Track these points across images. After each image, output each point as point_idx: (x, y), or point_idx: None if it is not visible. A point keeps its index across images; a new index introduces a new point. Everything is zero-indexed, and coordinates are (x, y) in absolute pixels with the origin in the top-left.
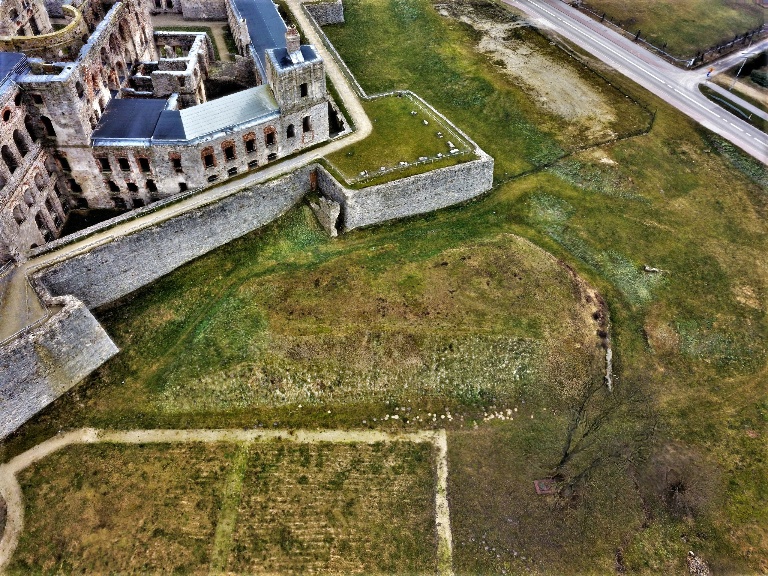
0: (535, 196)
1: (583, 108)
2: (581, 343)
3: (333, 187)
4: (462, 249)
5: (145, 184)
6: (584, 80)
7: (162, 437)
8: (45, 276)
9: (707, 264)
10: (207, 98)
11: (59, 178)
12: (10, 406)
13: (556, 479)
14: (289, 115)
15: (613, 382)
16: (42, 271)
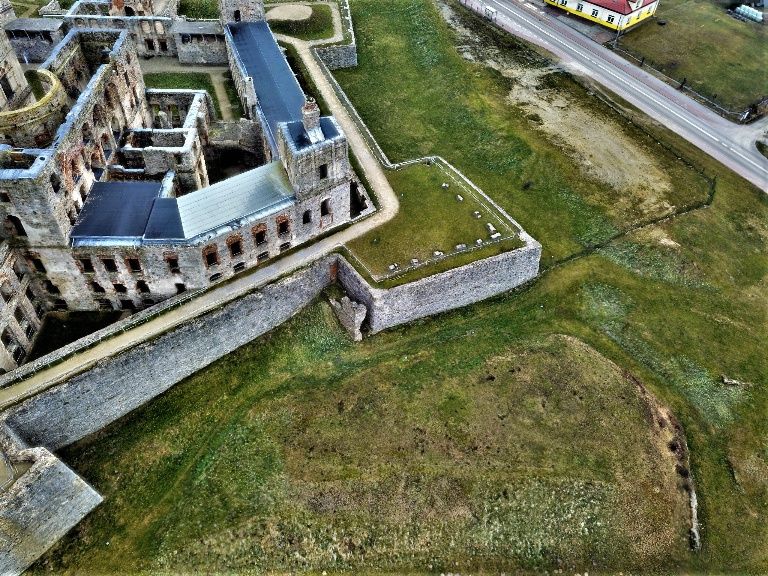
0: (587, 285)
1: (633, 174)
2: (660, 486)
3: (357, 284)
4: (509, 357)
5: (135, 285)
6: (630, 138)
7: None
8: (11, 418)
9: None
10: (207, 164)
11: (32, 280)
12: None
13: None
14: (306, 200)
15: (699, 534)
16: (7, 411)
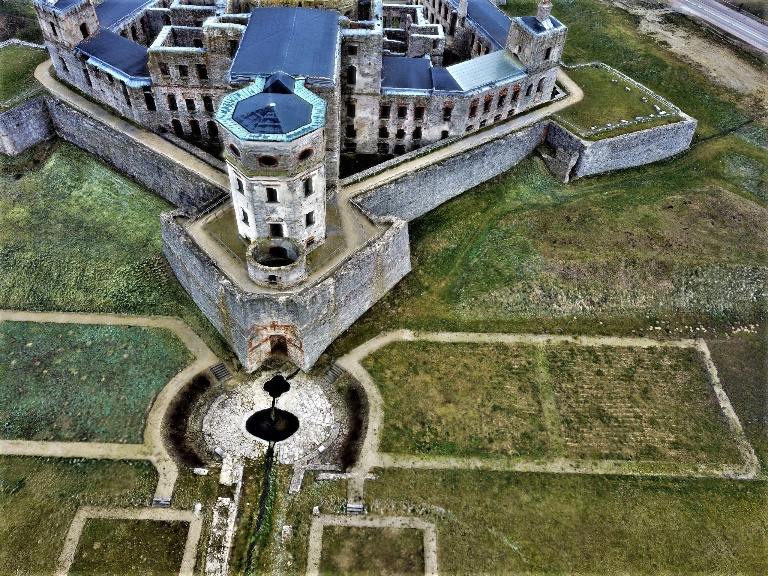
0: (728, 155)
1: (751, 83)
2: None
3: (568, 139)
4: (680, 196)
5: (413, 131)
6: (742, 60)
7: (469, 338)
8: (363, 201)
9: None
10: None
11: (341, 123)
12: (352, 306)
13: None
14: (533, 75)
15: None
16: (360, 196)
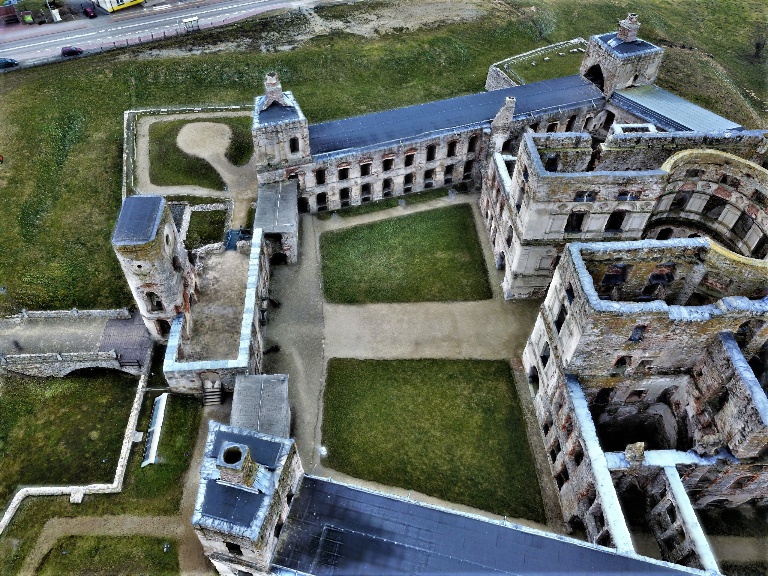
0: None
1: (465, 6)
2: None
3: None
4: None
5: None
6: (417, 0)
7: None
8: None
9: (601, 7)
10: None
11: None
12: None
13: None
14: None
15: None
16: None
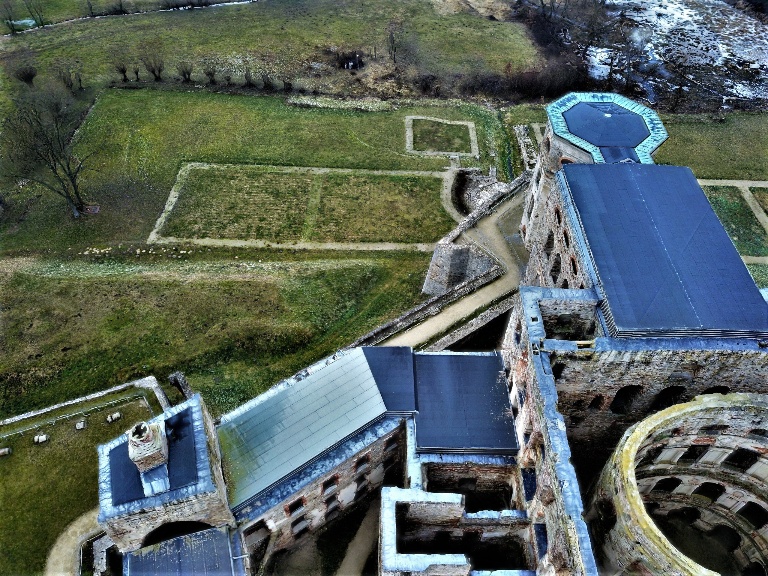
0: None
1: None
2: None
3: None
4: (31, 374)
5: None
6: None
7: (368, 245)
8: None
9: None
10: None
11: None
12: None
13: (81, 210)
14: None
15: None
16: (494, 273)
